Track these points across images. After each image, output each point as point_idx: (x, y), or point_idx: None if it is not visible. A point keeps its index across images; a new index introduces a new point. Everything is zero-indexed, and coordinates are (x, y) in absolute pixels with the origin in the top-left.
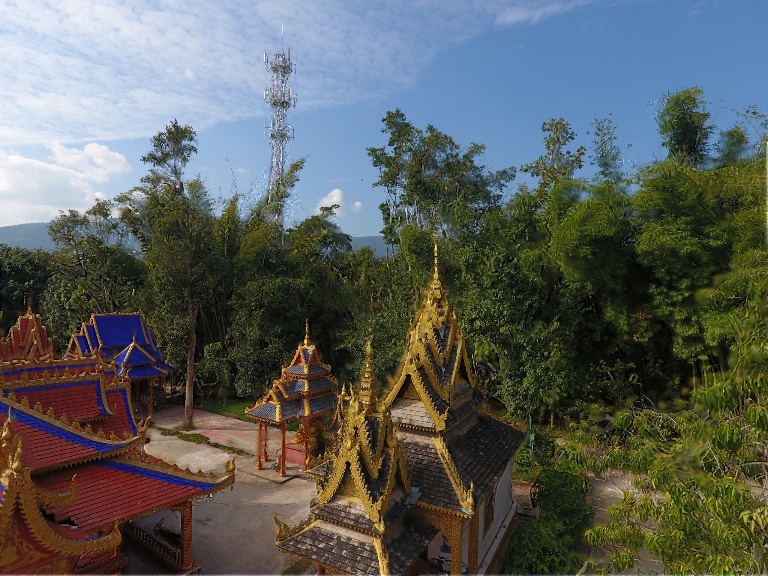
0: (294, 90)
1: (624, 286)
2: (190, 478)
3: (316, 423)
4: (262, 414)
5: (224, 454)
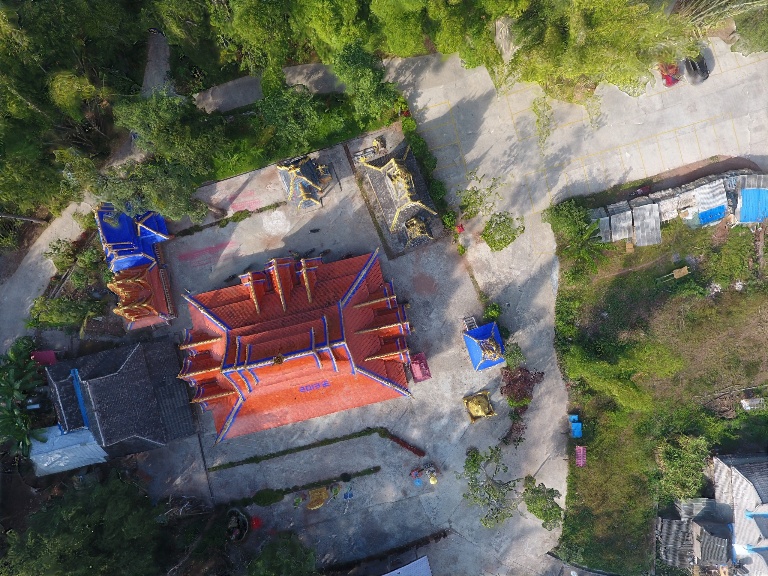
0: None
1: None
2: None
3: None
4: None
5: (275, 212)
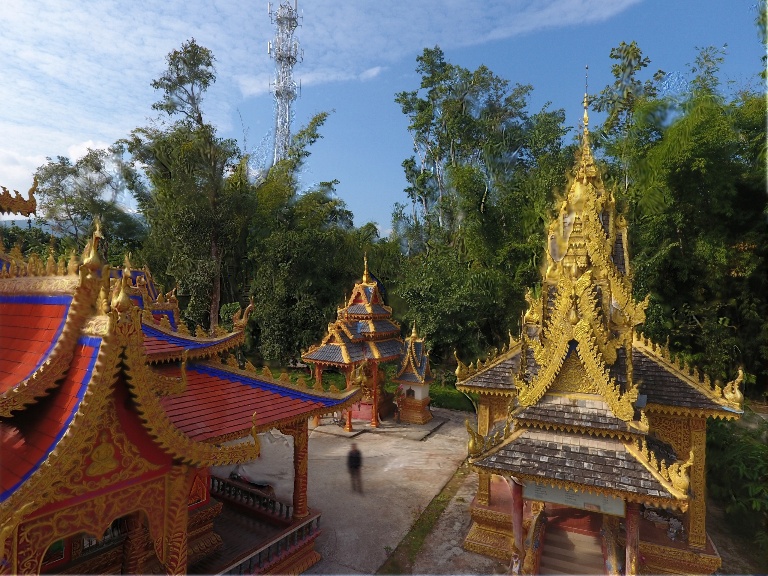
0: (300, 45)
1: (728, 211)
2: (306, 391)
3: (377, 374)
4: (324, 357)
5: None
